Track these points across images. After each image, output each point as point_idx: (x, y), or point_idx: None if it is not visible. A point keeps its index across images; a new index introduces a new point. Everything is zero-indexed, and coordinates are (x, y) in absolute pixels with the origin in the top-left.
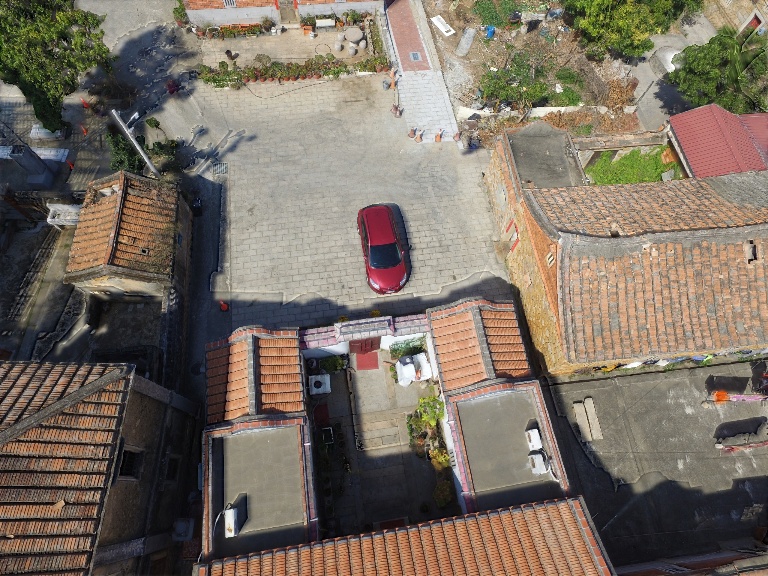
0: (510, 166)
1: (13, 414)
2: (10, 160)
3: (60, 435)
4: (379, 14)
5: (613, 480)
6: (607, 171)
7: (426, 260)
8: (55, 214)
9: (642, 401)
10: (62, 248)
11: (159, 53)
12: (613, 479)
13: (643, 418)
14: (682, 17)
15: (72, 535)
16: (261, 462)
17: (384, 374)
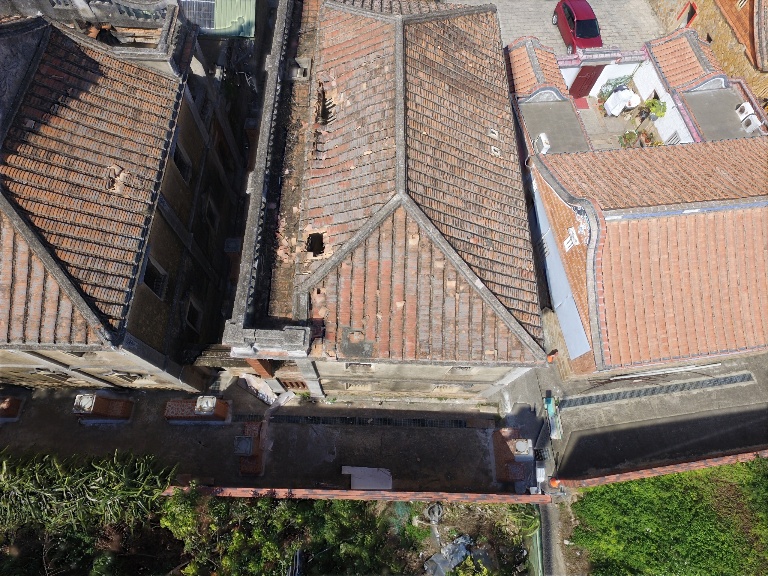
0: None
1: None
2: None
3: (475, 27)
4: None
5: None
6: None
7: (610, 44)
8: None
9: None
10: None
11: None
12: None
13: None
14: None
15: None
16: (549, 119)
17: (594, 112)
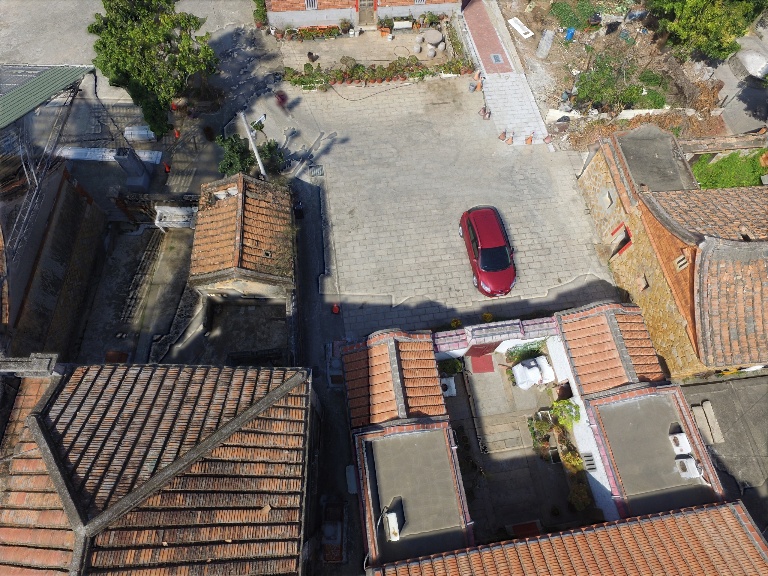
0: (622, 169)
1: (212, 418)
2: (105, 162)
3: (258, 439)
4: (457, 16)
5: (738, 483)
6: (702, 174)
7: (530, 263)
8: (161, 216)
9: (759, 404)
10: (167, 250)
11: (241, 55)
12: (738, 482)
13: (761, 421)
14: (759, 19)
15: (280, 539)
16: (412, 465)
17: (500, 377)
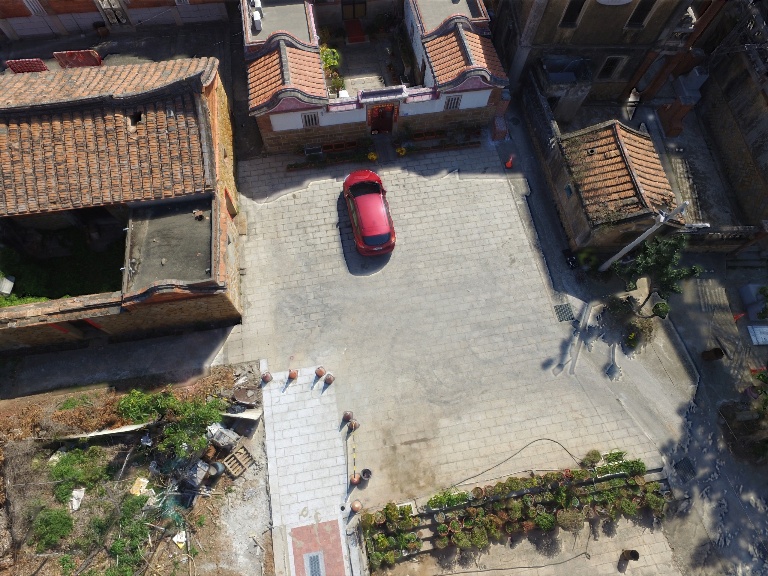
0: None
1: None
2: None
3: None
4: None
5: None
6: None
7: (322, 213)
8: None
9: None
10: None
11: (744, 551)
12: None
13: None
14: None
15: None
16: None
17: None
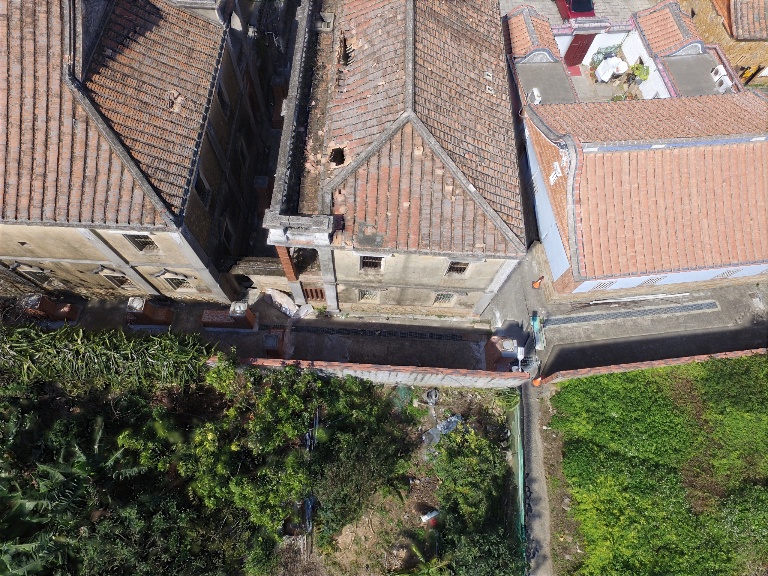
0: None
1: None
2: None
3: None
4: None
5: None
6: None
7: None
8: None
9: None
10: None
11: None
12: None
13: None
14: None
15: None
16: (542, 77)
17: (586, 78)
